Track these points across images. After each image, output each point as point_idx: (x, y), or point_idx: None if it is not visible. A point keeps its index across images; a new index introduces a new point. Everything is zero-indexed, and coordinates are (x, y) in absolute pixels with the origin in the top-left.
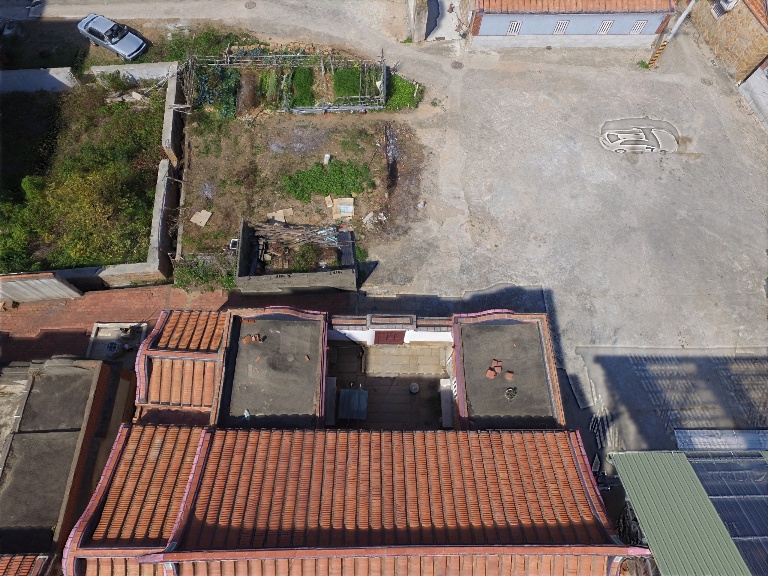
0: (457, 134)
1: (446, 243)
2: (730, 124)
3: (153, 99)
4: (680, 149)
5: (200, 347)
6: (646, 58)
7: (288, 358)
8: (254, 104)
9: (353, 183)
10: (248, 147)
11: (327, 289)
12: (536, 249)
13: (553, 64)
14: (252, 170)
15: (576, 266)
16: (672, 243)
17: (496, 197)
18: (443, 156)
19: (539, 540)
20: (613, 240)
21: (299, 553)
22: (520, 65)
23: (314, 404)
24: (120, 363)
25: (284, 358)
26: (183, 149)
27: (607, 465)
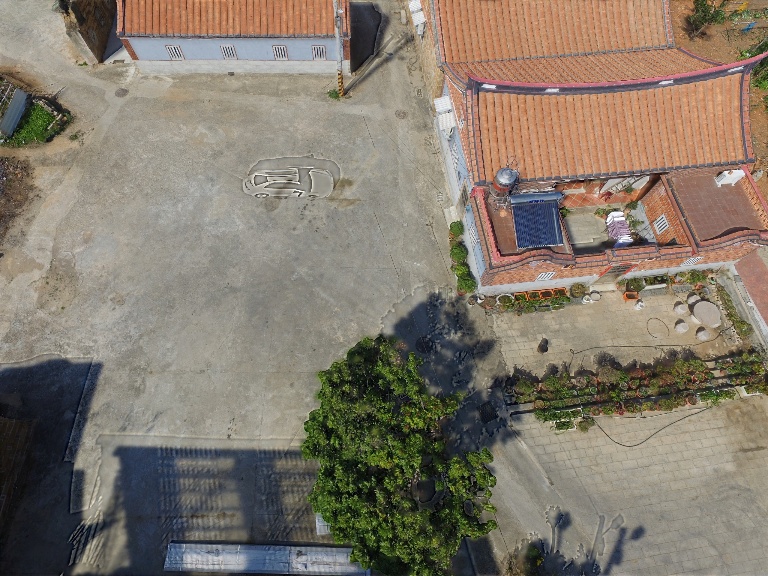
0: (80, 173)
1: (4, 304)
2: (407, 165)
3: None
4: (334, 194)
5: None
6: None
7: None
8: None
9: None
10: None
11: None
12: (108, 313)
13: (229, 92)
14: None
15: (146, 334)
16: (272, 308)
17: (90, 249)
18: (49, 199)
19: None
20: (203, 303)
21: None
22: (190, 93)
23: None
24: None
25: None
26: None
27: None
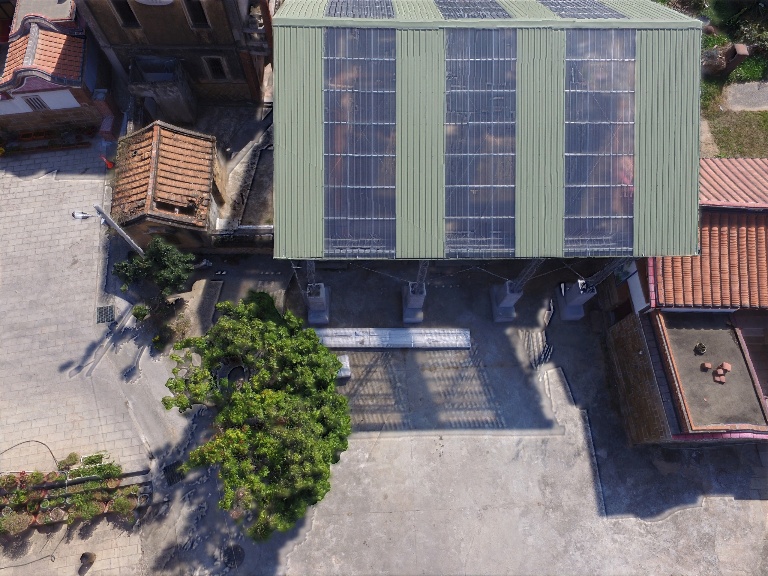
0: None
1: None
2: None
3: None
4: None
5: None
6: None
7: None
8: None
9: None
10: None
11: None
12: None
13: None
14: None
15: (562, 553)
16: None
17: None
18: None
19: (710, 215)
20: None
21: None
22: None
23: None
24: None
25: None
26: None
27: (538, 317)
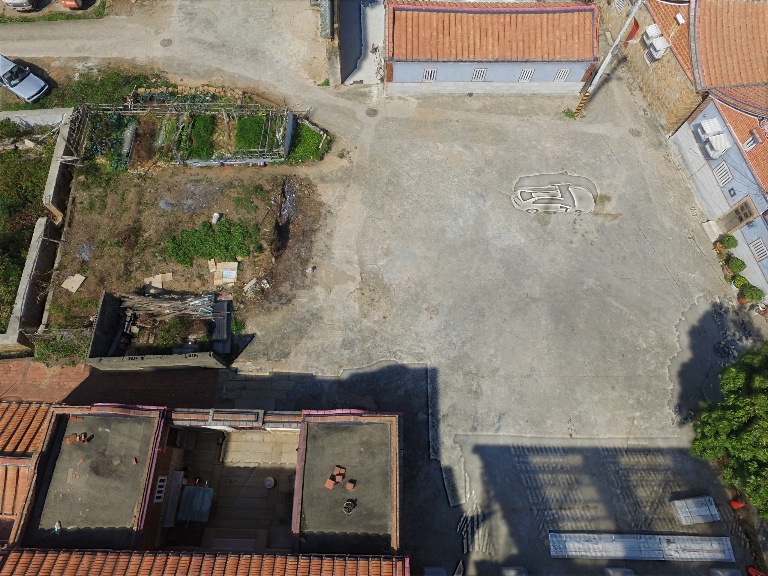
0: (360, 190)
1: (331, 314)
2: (654, 181)
3: (45, 148)
4: (597, 209)
5: (17, 449)
6: (573, 106)
7: (114, 461)
8: (149, 155)
9: (239, 246)
10: (134, 204)
11: (192, 367)
12: (427, 321)
13: (473, 112)
14: (135, 229)
15: (467, 341)
16: (574, 316)
17: (392, 262)
18: (341, 215)
19: None
20: (511, 312)
21: None
22: (437, 113)
23: (134, 515)
24: None
25: (109, 461)
26: (67, 204)
27: (471, 573)
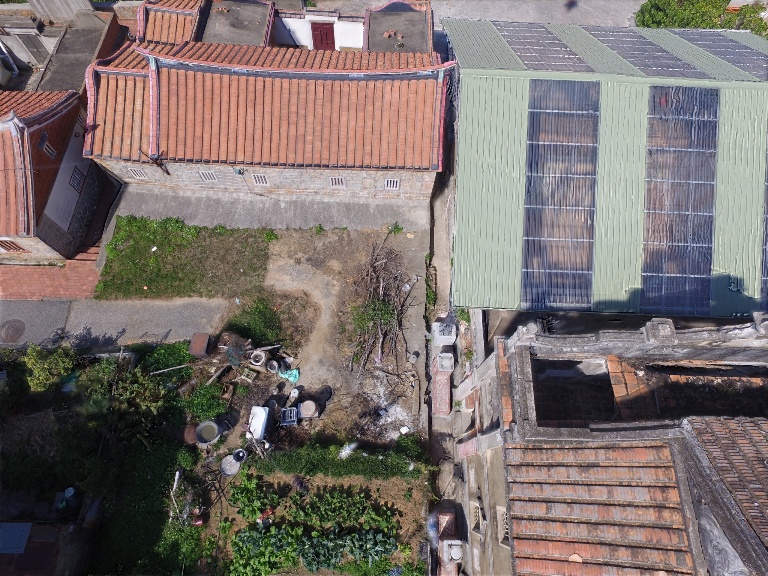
0: None
1: (377, 3)
2: None
3: None
4: None
5: None
6: None
7: (244, 22)
8: None
9: None
10: None
11: None
12: (447, 10)
13: None
14: None
15: None
16: (554, 11)
17: None
18: None
19: None
20: (508, 7)
21: (235, 65)
22: None
23: None
24: (127, 27)
25: (241, 22)
26: None
27: None
